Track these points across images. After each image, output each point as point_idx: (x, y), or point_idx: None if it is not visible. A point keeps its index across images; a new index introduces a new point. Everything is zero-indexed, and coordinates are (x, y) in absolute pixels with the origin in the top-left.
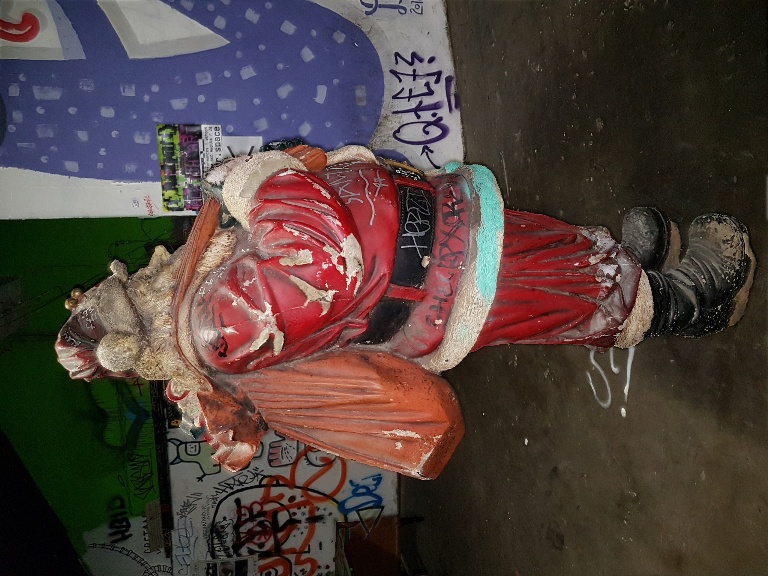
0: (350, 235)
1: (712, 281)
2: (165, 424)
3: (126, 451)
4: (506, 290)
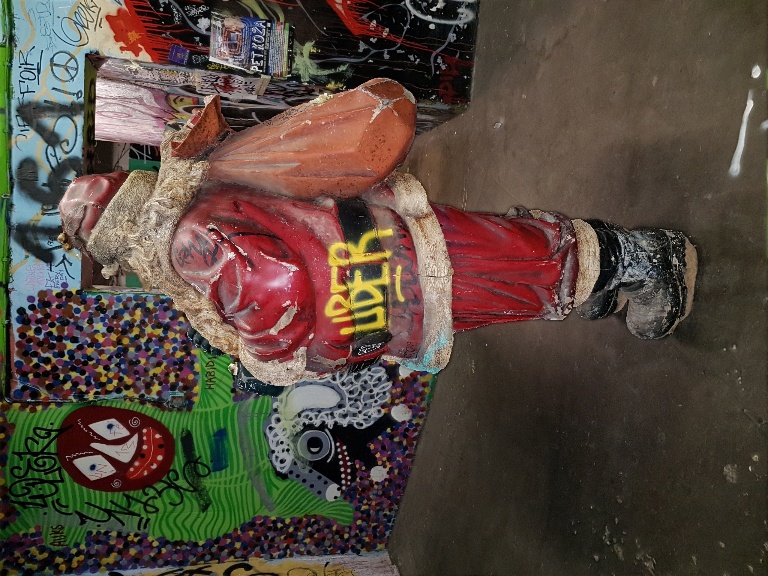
0: None
1: None
2: None
3: None
4: None
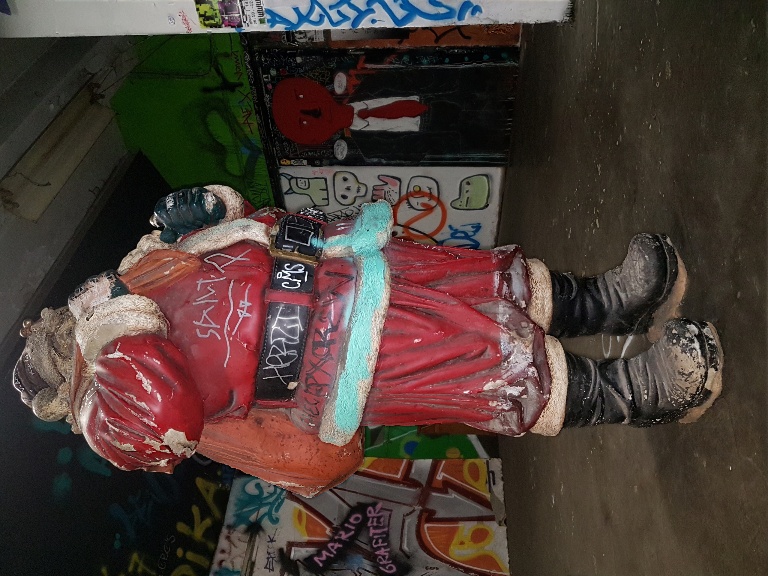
0: (169, 431)
1: (655, 399)
2: (276, 161)
3: (246, 179)
4: (383, 407)
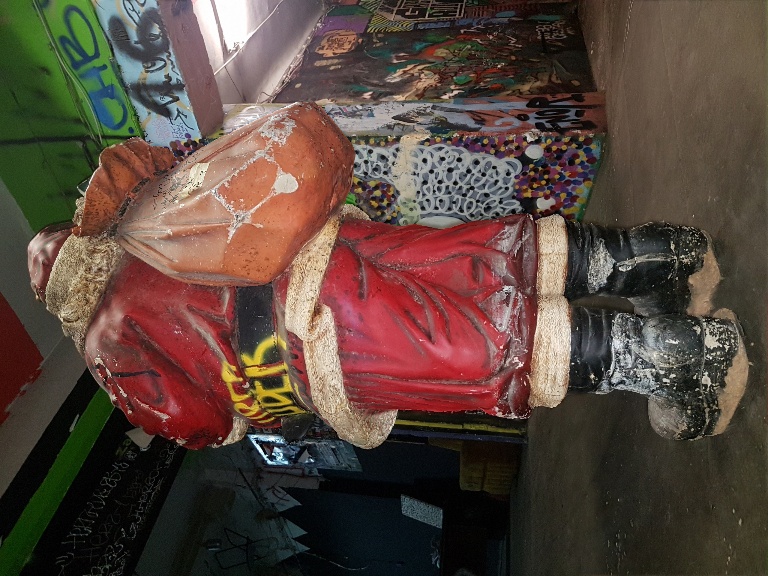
0: None
1: None
2: None
3: None
4: None
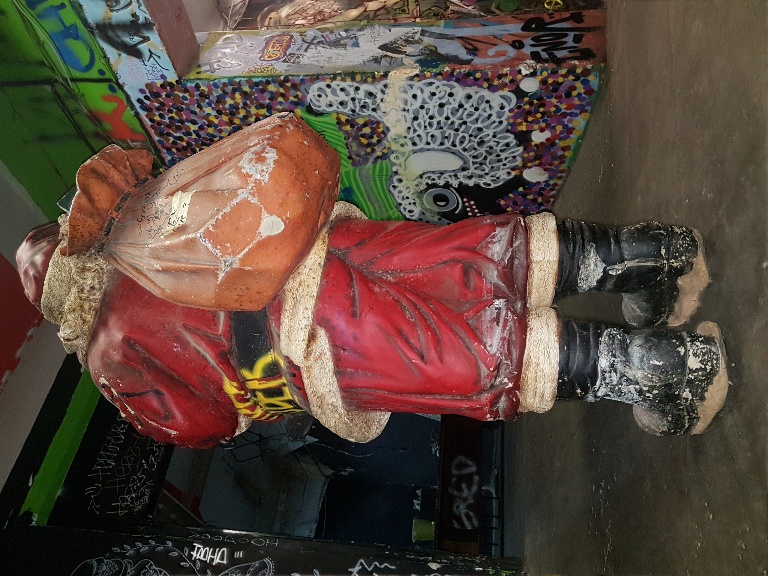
0: None
1: None
2: None
3: None
4: None
